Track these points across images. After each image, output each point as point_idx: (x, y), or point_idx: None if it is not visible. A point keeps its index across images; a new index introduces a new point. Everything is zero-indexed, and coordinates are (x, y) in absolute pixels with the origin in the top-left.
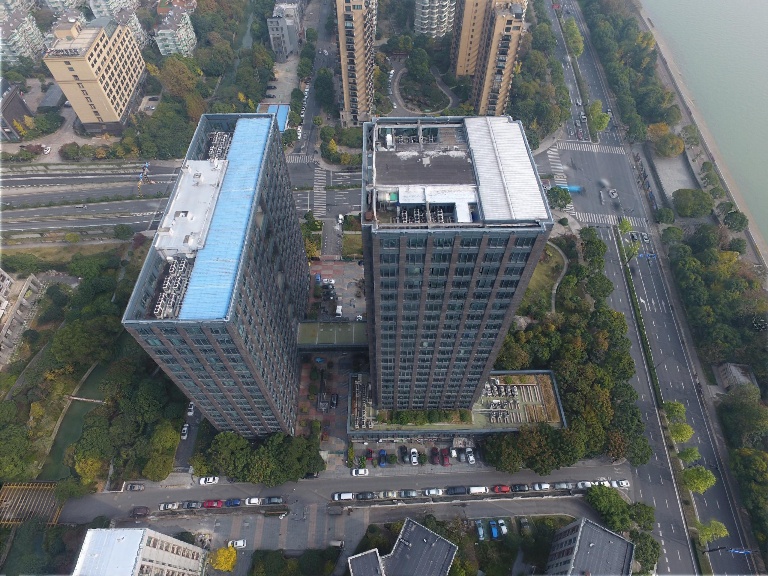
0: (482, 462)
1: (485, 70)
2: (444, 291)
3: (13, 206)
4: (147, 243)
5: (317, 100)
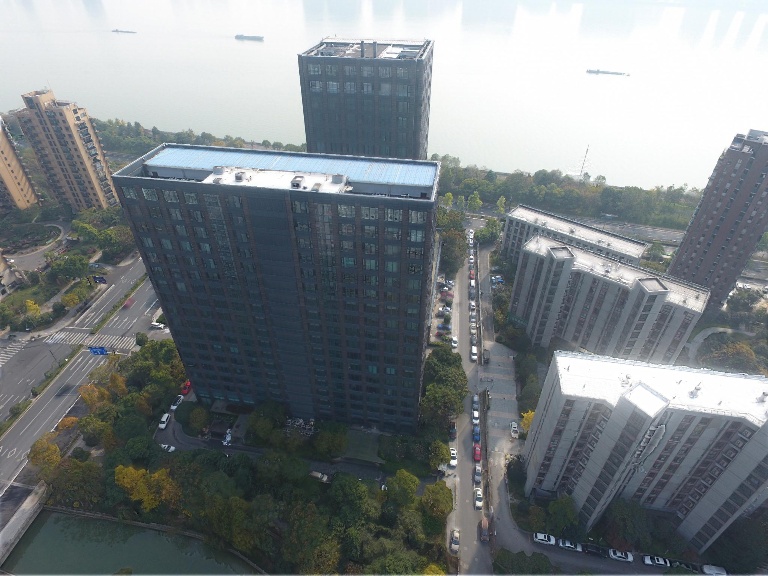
0: (453, 280)
1: (79, 167)
2: (425, 114)
3: None
4: None
5: None
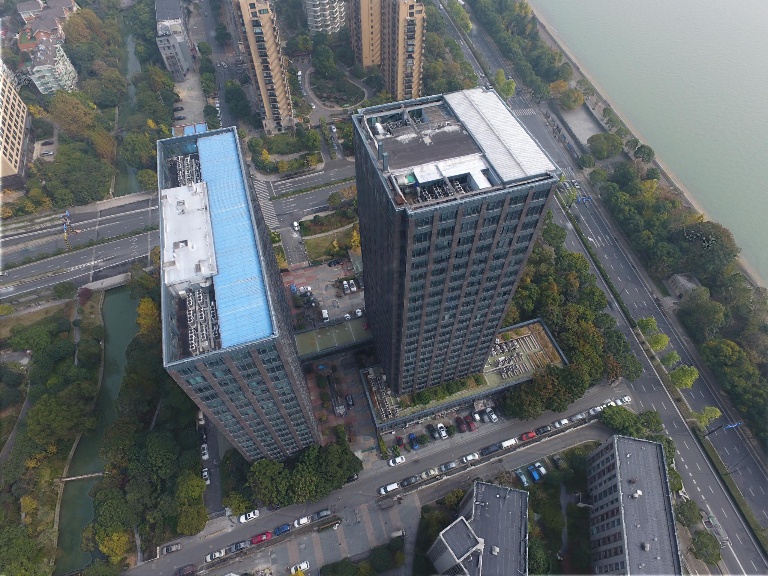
0: (504, 417)
1: (396, 57)
2: (468, 259)
3: None
4: (94, 296)
5: (232, 114)
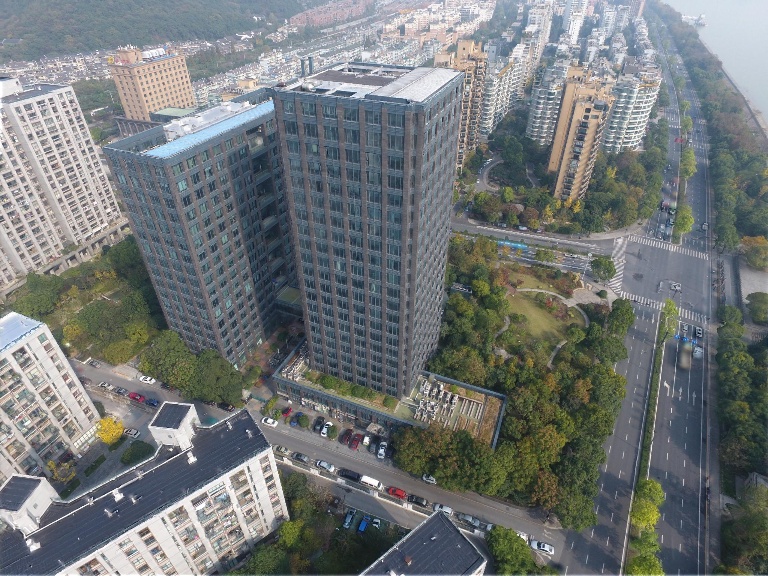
0: (392, 461)
1: (563, 155)
2: (341, 182)
3: None
4: None
5: None
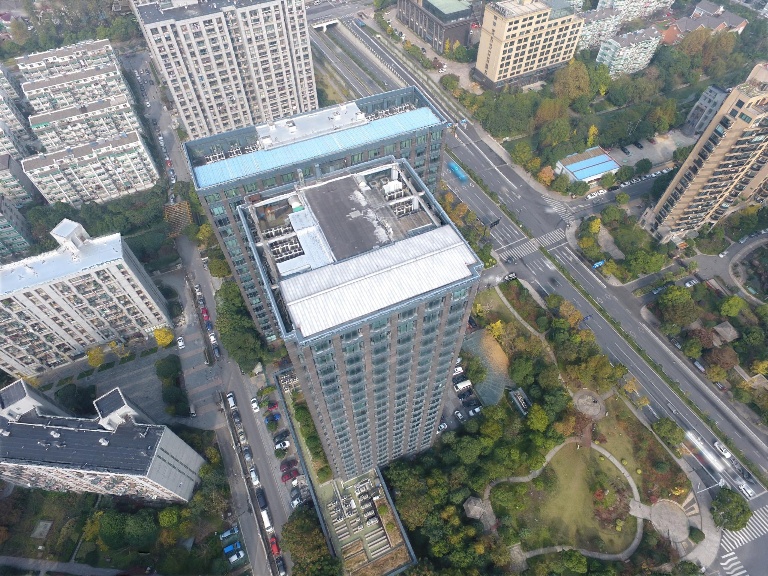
0: None
1: None
2: None
3: (386, 87)
4: None
5: None
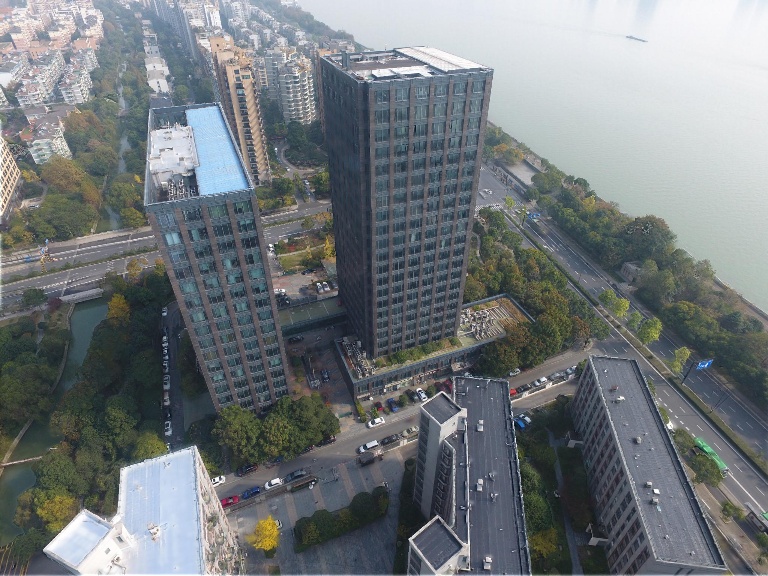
0: None
1: None
2: (425, 156)
3: None
4: (64, 307)
5: None
